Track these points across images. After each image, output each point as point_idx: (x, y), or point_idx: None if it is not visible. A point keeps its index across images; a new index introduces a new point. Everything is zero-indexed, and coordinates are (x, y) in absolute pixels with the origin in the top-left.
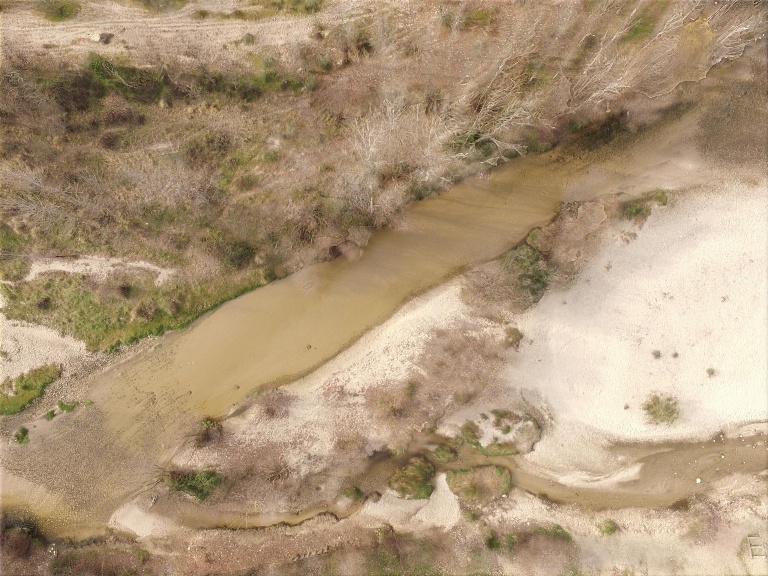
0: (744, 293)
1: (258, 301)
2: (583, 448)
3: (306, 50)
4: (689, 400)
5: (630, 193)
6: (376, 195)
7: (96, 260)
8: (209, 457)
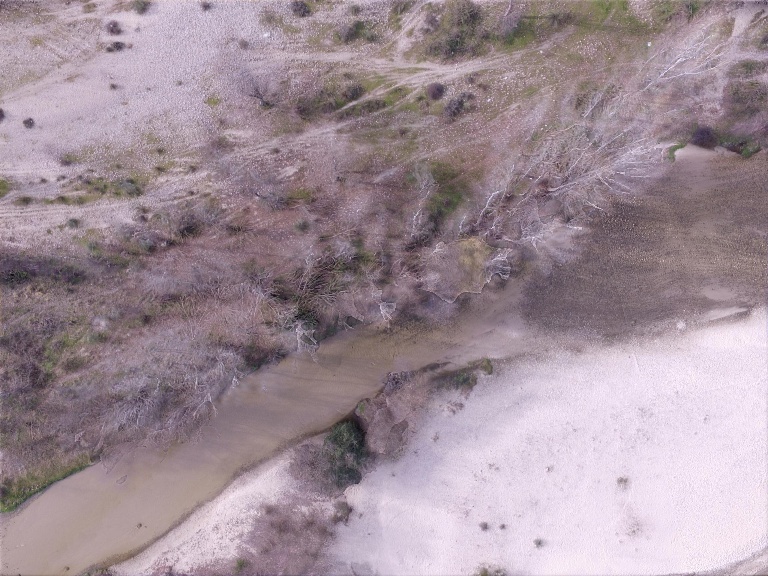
0: (568, 463)
1: (87, 481)
2: None
3: (129, 234)
4: (518, 571)
5: (456, 363)
6: (201, 375)
7: None
8: None
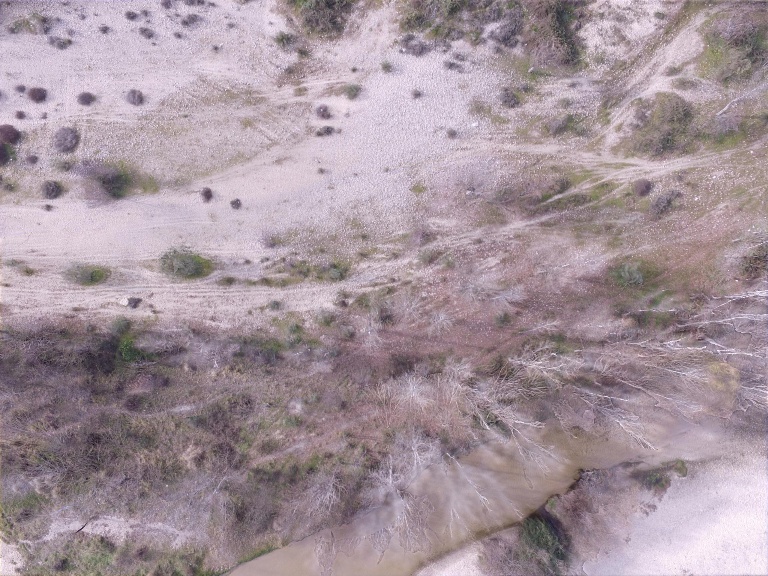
0: (765, 573)
1: (275, 563)
2: None
3: (330, 318)
4: None
5: (650, 463)
6: (396, 464)
7: (115, 521)
8: None
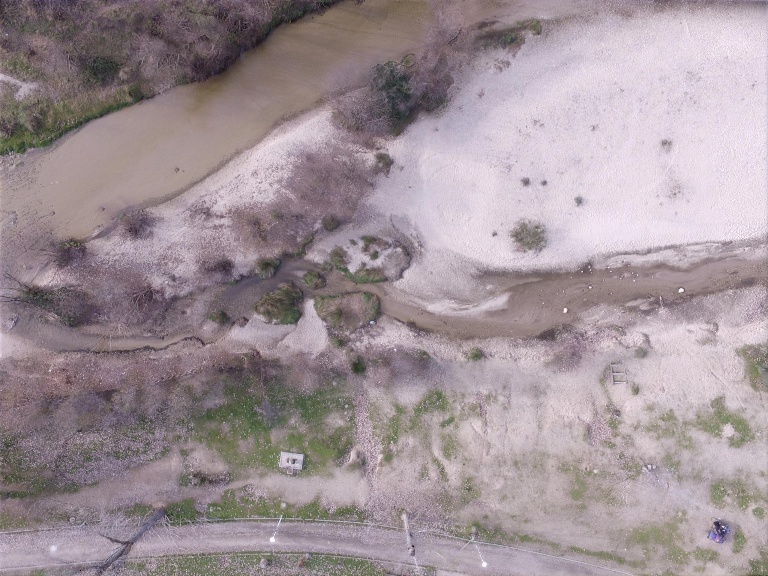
0: (614, 122)
1: (125, 121)
2: (452, 276)
3: None
4: (557, 229)
5: (505, 22)
6: None
7: None
8: (71, 277)
